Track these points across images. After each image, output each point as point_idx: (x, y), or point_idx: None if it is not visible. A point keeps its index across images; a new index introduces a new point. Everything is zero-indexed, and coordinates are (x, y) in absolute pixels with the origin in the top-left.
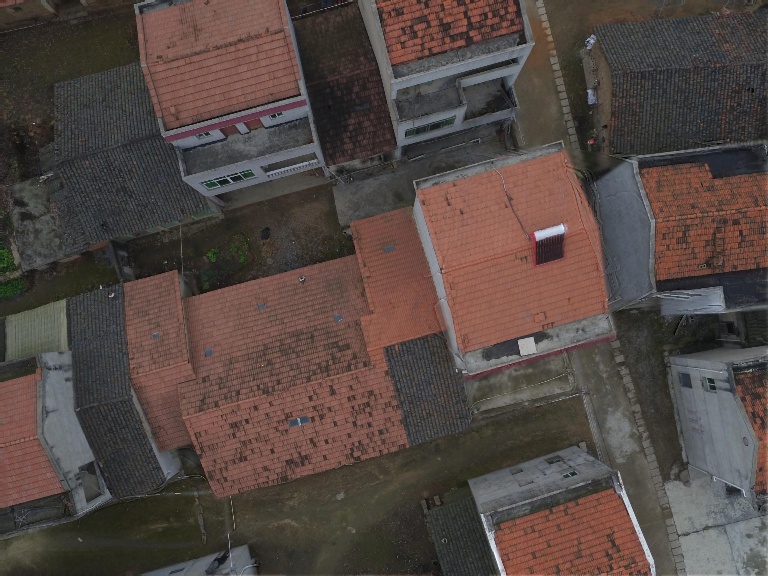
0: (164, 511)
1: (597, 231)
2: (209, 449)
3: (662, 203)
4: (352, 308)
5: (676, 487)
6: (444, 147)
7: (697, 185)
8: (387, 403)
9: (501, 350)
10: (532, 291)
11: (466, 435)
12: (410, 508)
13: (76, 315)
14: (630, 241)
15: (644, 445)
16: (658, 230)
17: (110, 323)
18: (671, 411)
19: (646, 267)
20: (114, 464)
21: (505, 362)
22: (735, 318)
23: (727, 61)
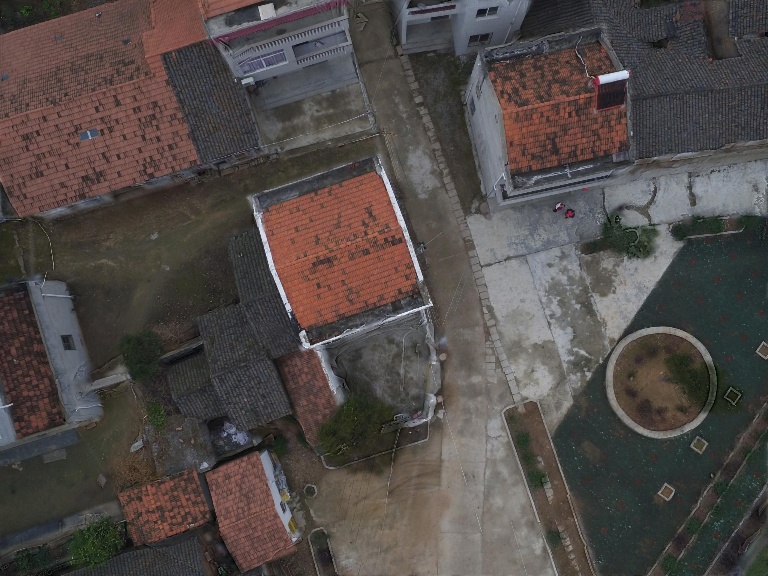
0: None
1: None
2: (5, 163)
3: None
4: None
5: (477, 220)
6: None
7: None
8: (172, 116)
9: (243, 17)
10: None
11: (273, 175)
12: (220, 244)
13: None
14: None
15: (445, 181)
16: None
17: None
18: (470, 147)
19: None
20: None
21: (245, 25)
22: None
23: None
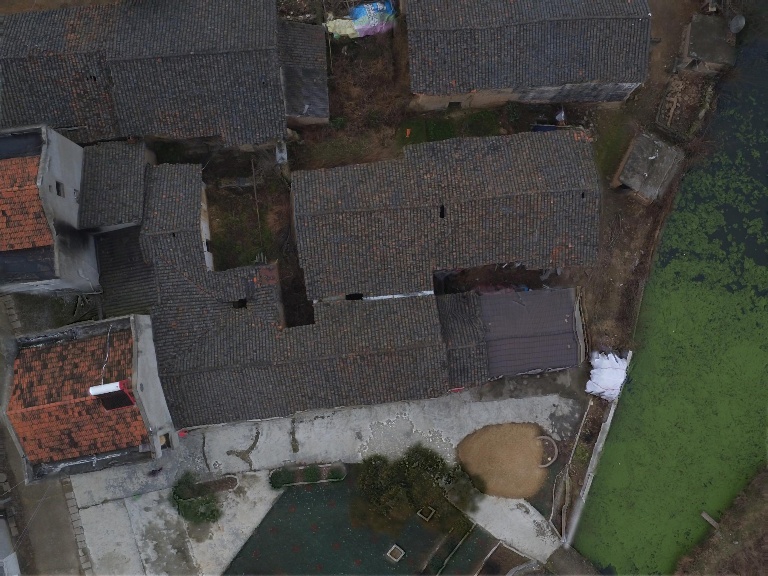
0: None
1: None
2: None
3: None
4: None
5: None
6: None
7: None
8: None
9: None
10: None
11: None
12: None
13: None
14: None
15: None
16: None
17: None
18: None
19: None
20: None
21: None
22: None
23: (61, 50)
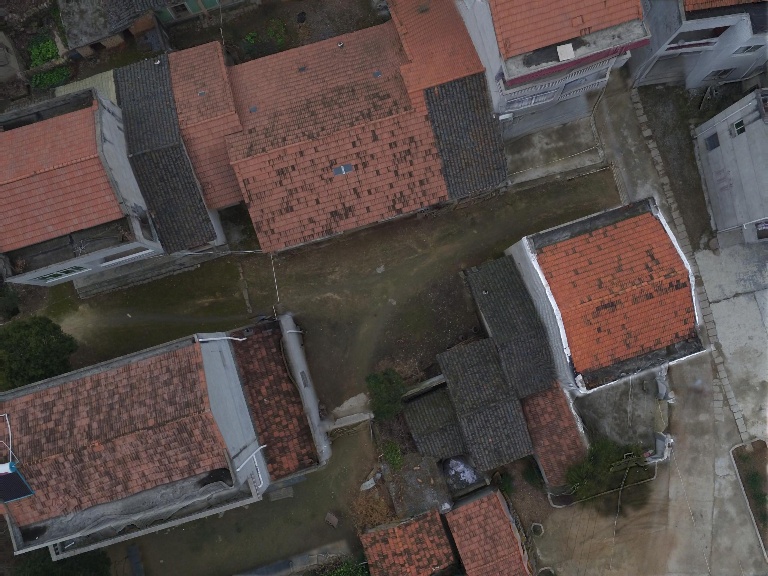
0: (210, 286)
1: None
2: (257, 197)
3: None
4: (390, 65)
5: (706, 256)
6: None
7: None
8: (427, 151)
9: (541, 57)
10: None
11: (501, 209)
12: (448, 279)
13: (124, 81)
14: None
15: (673, 216)
16: None
17: (157, 85)
18: (699, 182)
19: None
20: (165, 215)
21: (545, 66)
22: (759, 81)
23: None
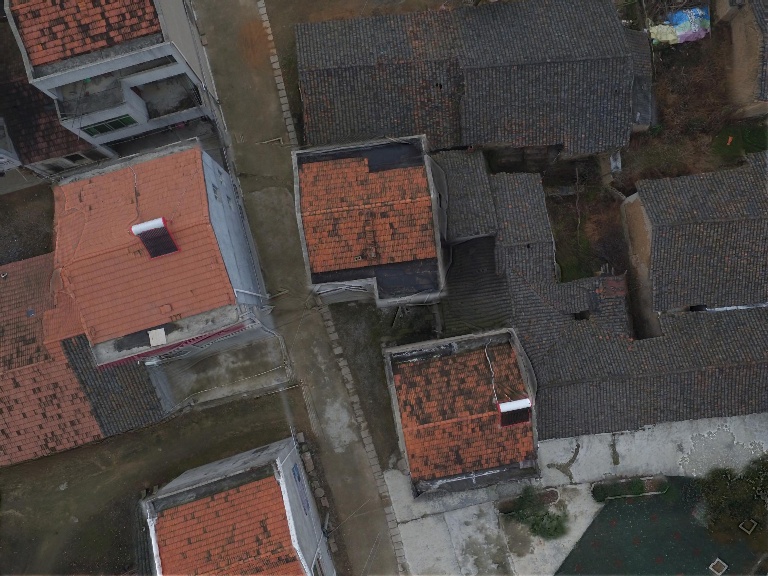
0: None
1: (237, 225)
2: None
3: (314, 197)
4: (45, 303)
5: (395, 476)
6: (159, 145)
7: (352, 179)
8: (74, 395)
9: (132, 341)
10: (151, 284)
11: (186, 426)
12: (130, 498)
13: None
14: (278, 235)
15: (362, 435)
16: (307, 224)
17: None
18: (389, 401)
19: (300, 260)
20: None
21: (133, 353)
22: (438, 309)
23: (411, 58)
